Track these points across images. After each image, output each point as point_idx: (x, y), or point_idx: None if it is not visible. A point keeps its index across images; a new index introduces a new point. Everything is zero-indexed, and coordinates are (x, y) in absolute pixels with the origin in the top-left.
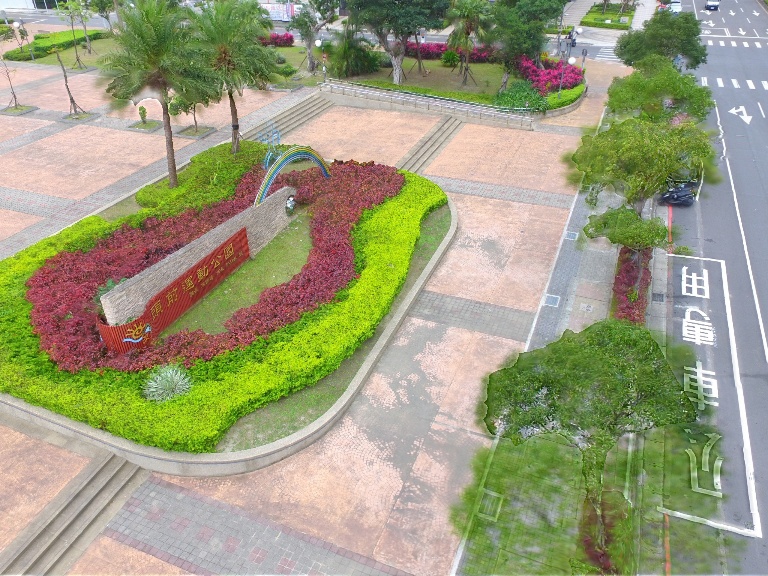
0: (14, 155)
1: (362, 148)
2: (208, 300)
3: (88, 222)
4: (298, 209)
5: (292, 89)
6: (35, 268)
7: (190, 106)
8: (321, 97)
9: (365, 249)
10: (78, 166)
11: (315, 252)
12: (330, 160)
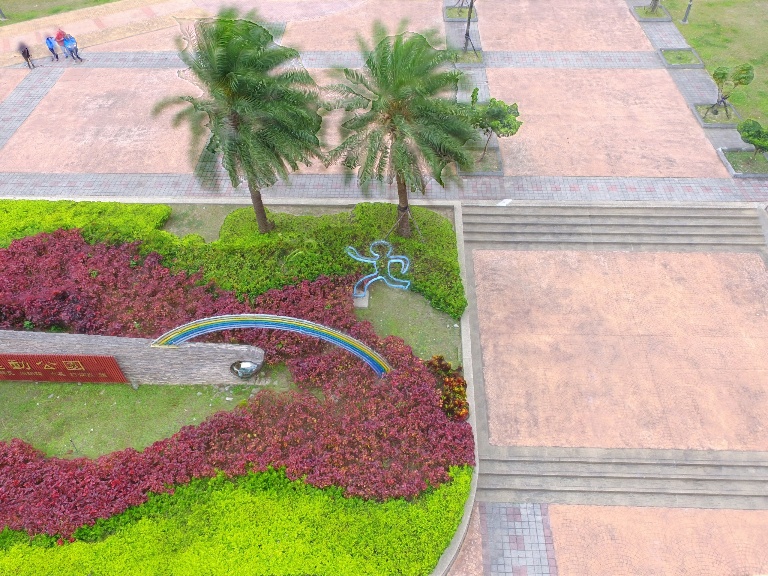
0: (339, 75)
1: (581, 365)
2: (35, 387)
3: (151, 212)
4: (288, 375)
5: (740, 173)
6: (50, 228)
7: (487, 127)
8: (758, 218)
9: (143, 521)
10: (328, 127)
11: (120, 456)
12: (466, 346)
